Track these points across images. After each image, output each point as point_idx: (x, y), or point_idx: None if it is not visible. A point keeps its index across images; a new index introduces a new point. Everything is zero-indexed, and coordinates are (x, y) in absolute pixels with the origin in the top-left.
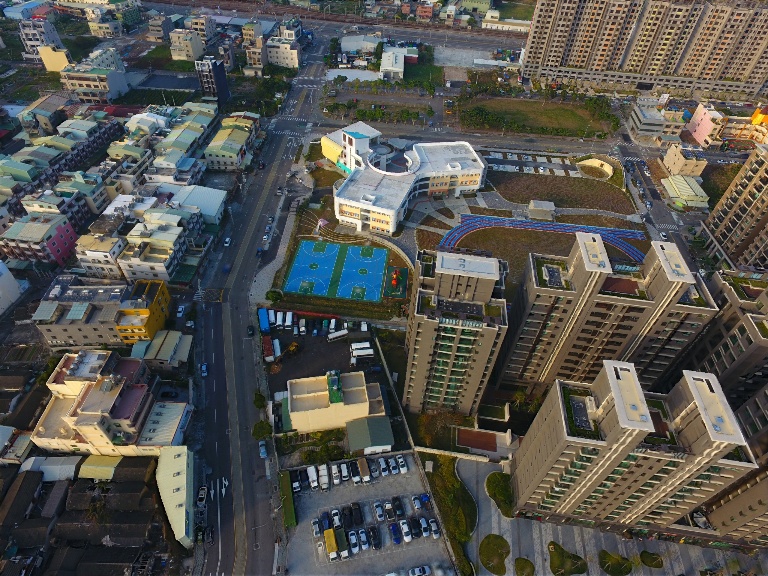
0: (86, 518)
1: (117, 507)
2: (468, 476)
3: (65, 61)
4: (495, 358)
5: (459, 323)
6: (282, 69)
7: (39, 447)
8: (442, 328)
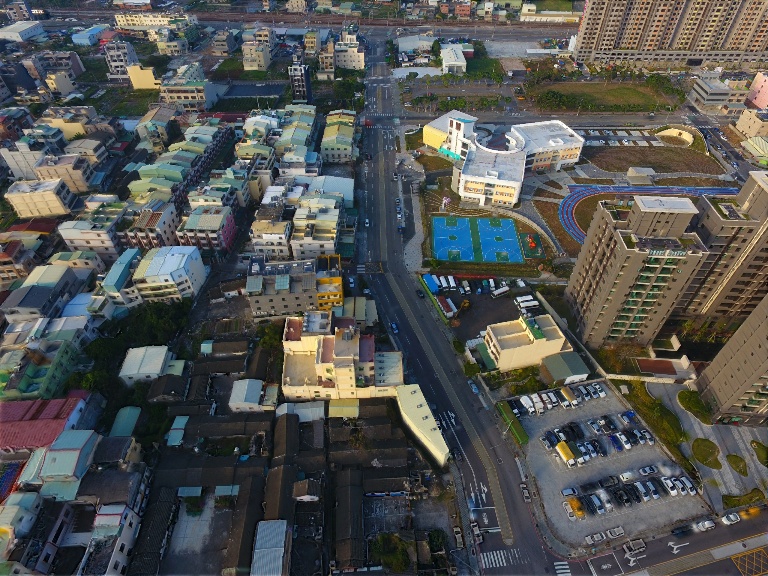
0: (353, 446)
1: (374, 437)
2: (660, 395)
3: (152, 78)
4: (688, 285)
5: (665, 253)
6: (351, 71)
7: (284, 396)
8: (647, 260)
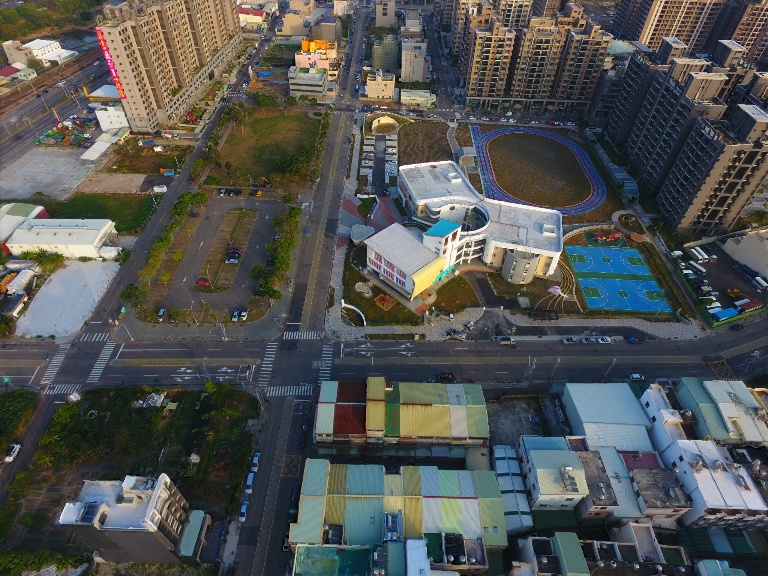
0: None
1: None
2: (743, 213)
3: None
4: None
5: None
6: None
7: None
8: None
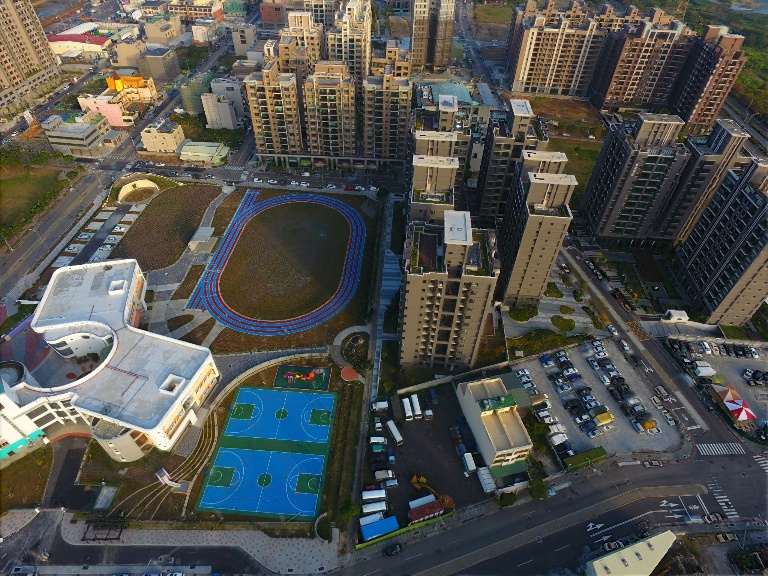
0: None
1: None
2: (517, 331)
3: None
4: None
5: None
6: None
7: None
8: None
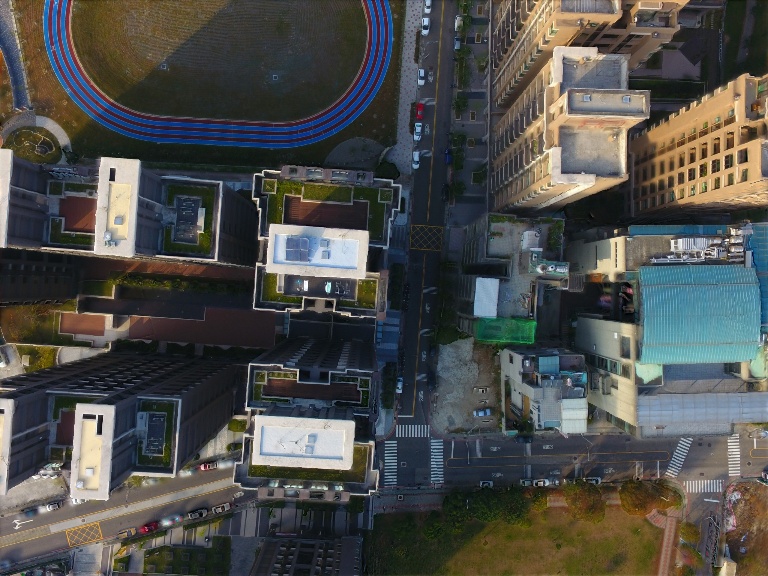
0: None
1: None
2: None
3: None
4: None
5: None
6: None
7: None
8: None
